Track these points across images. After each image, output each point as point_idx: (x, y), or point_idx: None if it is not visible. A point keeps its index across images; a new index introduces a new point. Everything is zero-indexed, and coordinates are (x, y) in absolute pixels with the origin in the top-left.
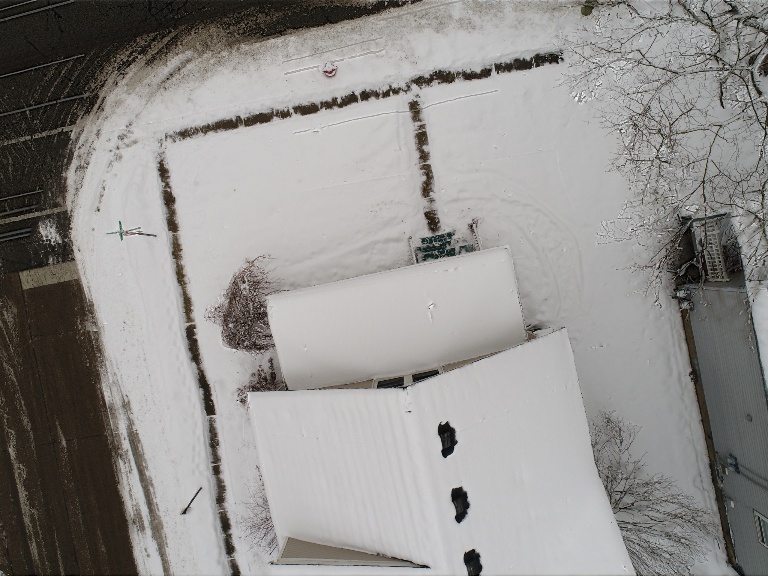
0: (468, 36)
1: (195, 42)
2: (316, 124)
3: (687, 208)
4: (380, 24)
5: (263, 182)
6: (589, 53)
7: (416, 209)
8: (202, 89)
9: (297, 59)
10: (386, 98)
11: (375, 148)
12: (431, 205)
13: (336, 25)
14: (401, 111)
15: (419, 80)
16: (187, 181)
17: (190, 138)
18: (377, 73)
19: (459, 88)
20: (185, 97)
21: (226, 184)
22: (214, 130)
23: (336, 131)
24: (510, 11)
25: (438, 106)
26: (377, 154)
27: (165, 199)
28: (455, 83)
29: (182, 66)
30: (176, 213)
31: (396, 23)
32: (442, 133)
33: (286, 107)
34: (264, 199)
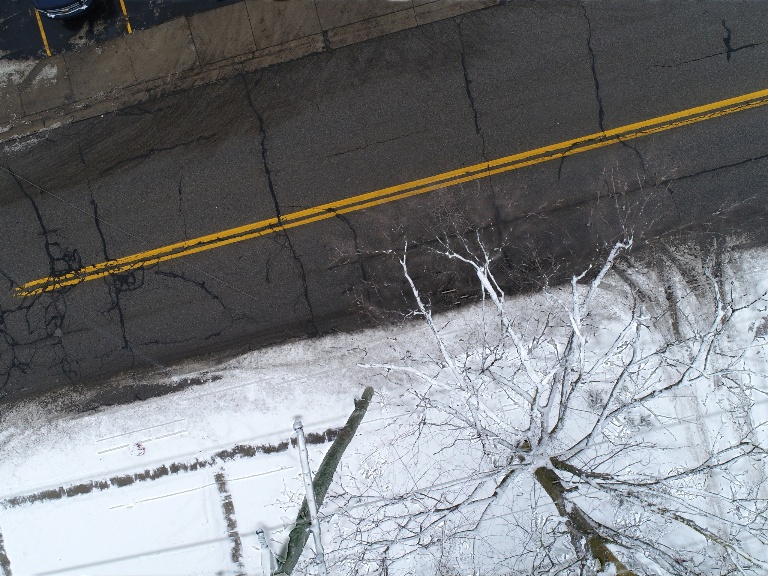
0: (263, 416)
1: (17, 419)
2: (130, 499)
3: (470, 575)
4: (183, 404)
5: (85, 553)
6: (376, 428)
7: (226, 575)
8: (24, 467)
9: (109, 438)
10: (193, 472)
11: (183, 523)
12: (241, 569)
13: (144, 404)
14: (207, 484)
15: (223, 454)
16: (17, 550)
17: (19, 506)
18: (183, 450)
19: (258, 464)
20: (10, 473)
21: (52, 554)
22: (40, 500)
23: (148, 507)
24: (300, 393)
25: (240, 481)
26: (186, 528)
27: (1, 561)
28: (255, 457)
29: (7, 440)
30: (12, 573)
31: (197, 405)
32: (245, 507)
33: (104, 479)
34: (87, 569)
